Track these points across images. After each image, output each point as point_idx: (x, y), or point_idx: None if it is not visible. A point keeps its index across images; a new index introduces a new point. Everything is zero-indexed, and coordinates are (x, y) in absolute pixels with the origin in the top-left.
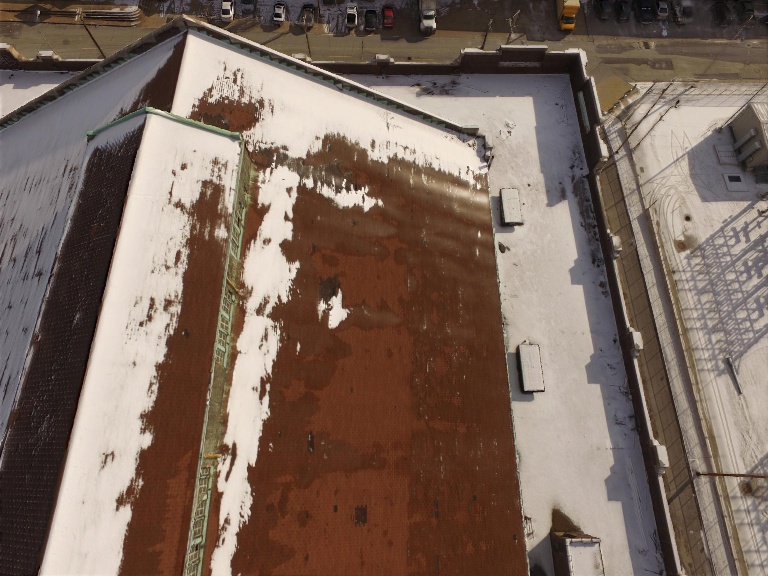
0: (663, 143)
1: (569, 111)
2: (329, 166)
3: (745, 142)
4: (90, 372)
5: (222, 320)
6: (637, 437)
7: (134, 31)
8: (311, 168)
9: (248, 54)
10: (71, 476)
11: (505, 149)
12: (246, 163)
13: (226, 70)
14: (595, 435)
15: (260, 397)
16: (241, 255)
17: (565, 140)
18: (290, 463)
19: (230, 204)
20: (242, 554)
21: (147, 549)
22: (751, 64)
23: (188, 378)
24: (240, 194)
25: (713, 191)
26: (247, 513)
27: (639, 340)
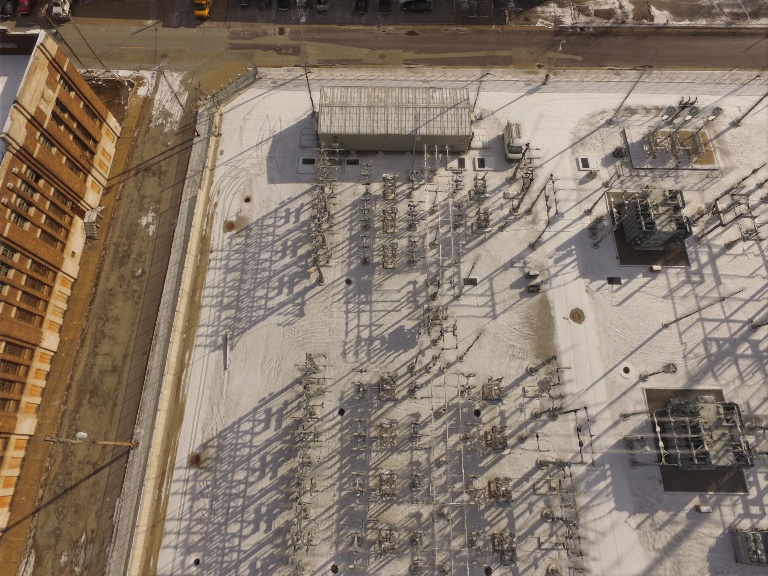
0: (253, 127)
1: None
2: None
3: None
4: None
5: None
6: None
7: None
8: None
9: None
10: None
11: None
12: None
13: None
14: None
15: None
16: None
17: None
18: None
19: None
20: None
21: None
22: (378, 50)
23: None
24: None
25: (282, 173)
26: None
27: None
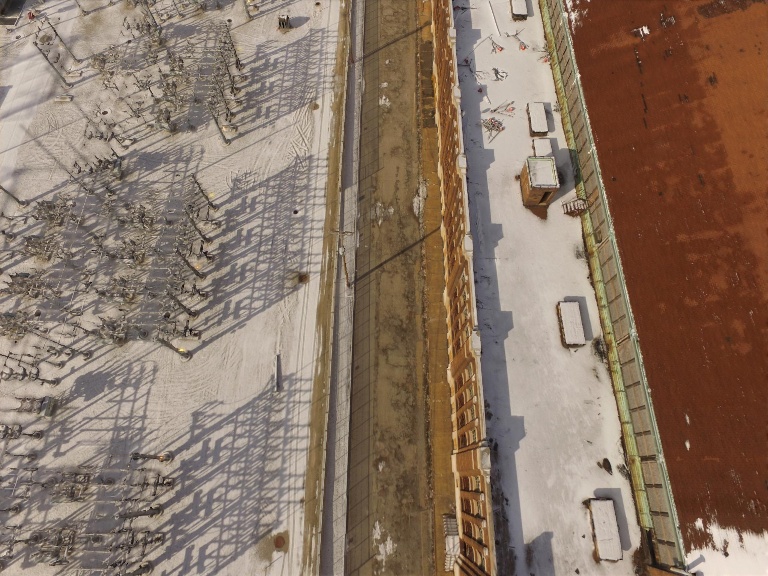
0: None
1: None
2: None
3: None
4: None
5: None
6: None
7: None
8: None
9: None
10: None
11: None
12: None
13: None
14: (509, 269)
15: None
16: None
17: None
18: None
19: None
20: None
21: None
22: None
23: None
24: None
25: None
26: None
27: (476, 340)
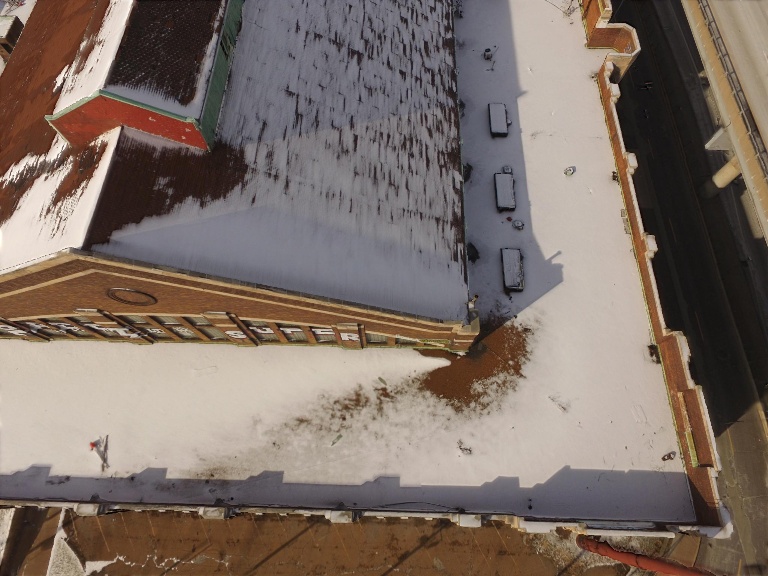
0: None
1: None
2: None
3: None
4: None
5: None
6: None
7: None
8: None
9: None
10: None
11: None
12: None
13: None
14: None
15: None
16: None
17: None
18: None
19: None
20: None
21: None
22: None
23: None
24: None
25: None
26: None
27: None
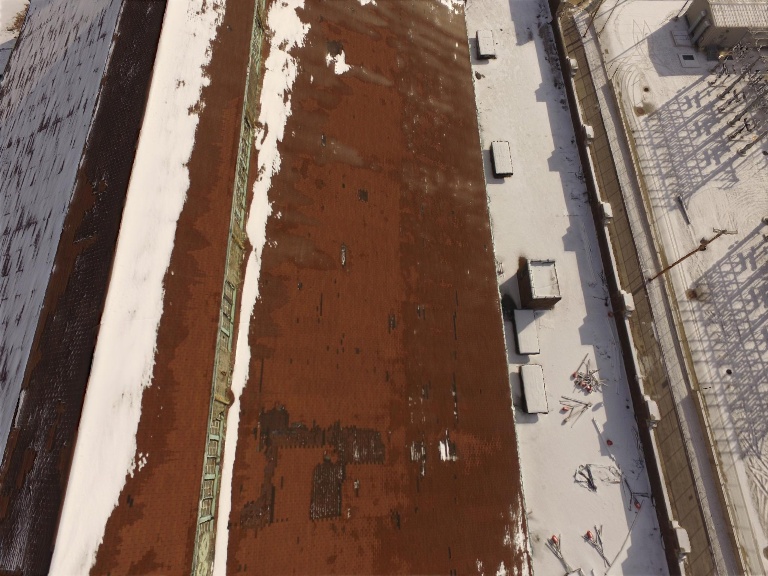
0: (626, 30)
1: None
2: None
3: (697, 24)
4: (165, 30)
5: (254, 36)
6: (589, 208)
7: None
8: None
9: None
10: (157, 85)
11: (481, 3)
12: None
13: None
14: (555, 207)
15: (284, 101)
16: (265, 8)
17: None
18: (308, 148)
19: None
20: (275, 191)
21: (211, 143)
22: None
23: (233, 55)
24: None
25: (669, 67)
26: (278, 168)
27: (590, 131)
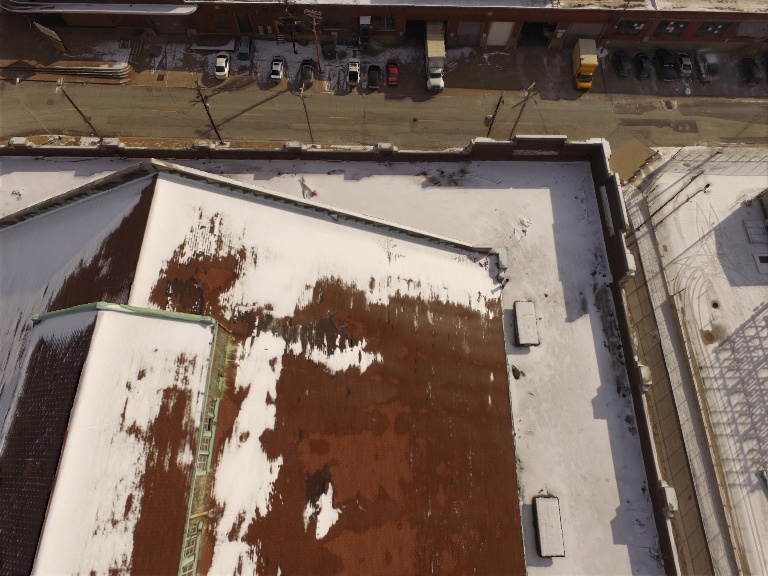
0: (688, 218)
1: (590, 206)
2: (321, 321)
3: None
4: None
5: (184, 570)
6: None
7: (123, 89)
8: (299, 328)
9: (229, 192)
10: None
11: (519, 252)
12: (221, 343)
13: (202, 217)
14: None
15: None
16: (212, 462)
17: (586, 241)
18: None
19: (197, 415)
20: None
21: None
22: None
23: None
24: (212, 389)
25: (743, 274)
26: None
27: (673, 499)
